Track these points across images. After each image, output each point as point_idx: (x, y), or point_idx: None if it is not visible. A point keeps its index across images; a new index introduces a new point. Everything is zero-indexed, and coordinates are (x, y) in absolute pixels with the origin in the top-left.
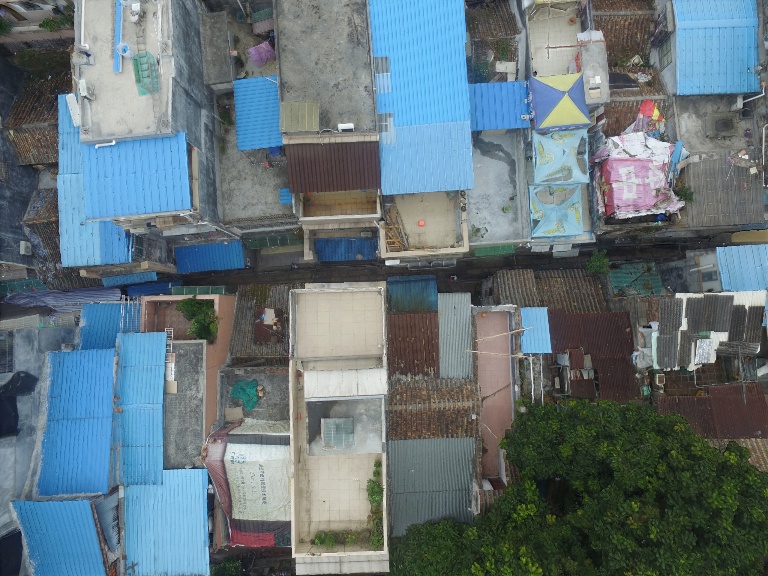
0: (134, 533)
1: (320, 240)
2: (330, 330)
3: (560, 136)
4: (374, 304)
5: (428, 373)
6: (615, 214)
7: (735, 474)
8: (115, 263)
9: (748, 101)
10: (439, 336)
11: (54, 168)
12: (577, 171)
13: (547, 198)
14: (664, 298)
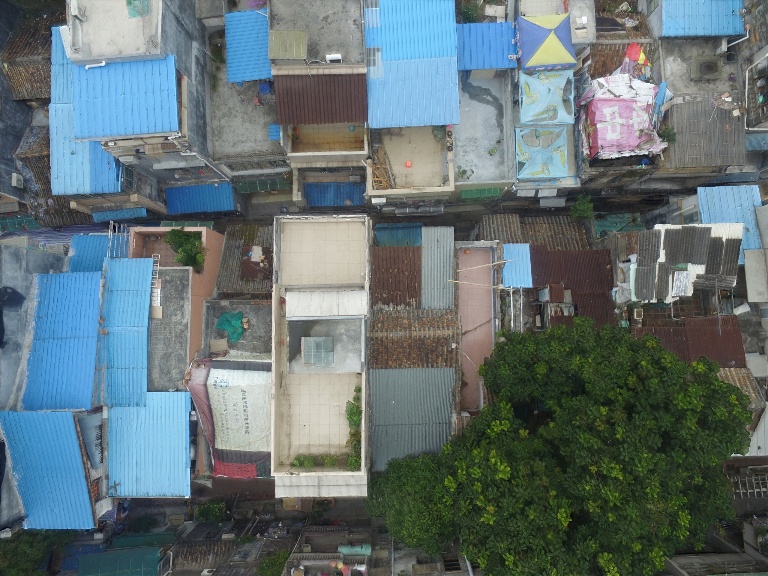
0: (117, 453)
1: (309, 185)
2: (314, 259)
3: (546, 76)
4: (358, 234)
5: (410, 303)
6: (599, 154)
7: (702, 382)
8: (104, 193)
9: (733, 45)
10: (422, 268)
11: (47, 106)
12: (562, 111)
13: (534, 143)
14: (643, 230)
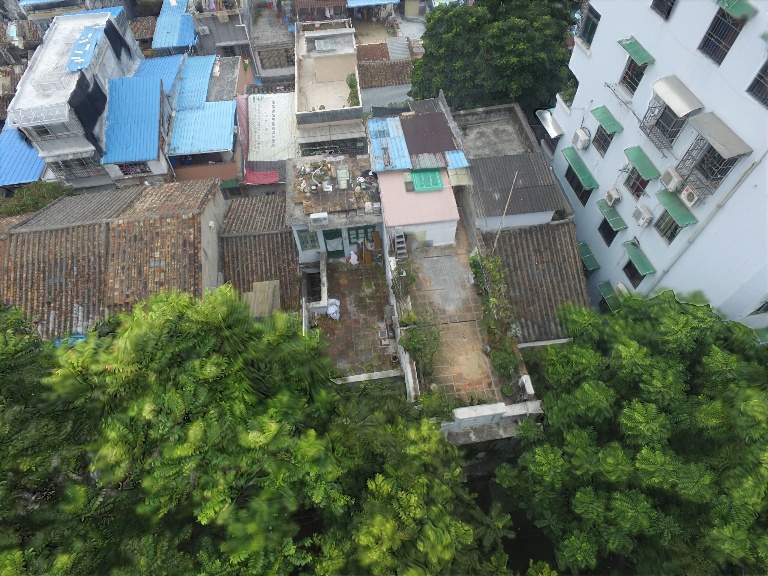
0: (179, 133)
1: None
2: None
3: None
4: None
5: None
6: None
7: None
8: (185, 47)
9: None
10: (388, 48)
11: (146, 49)
12: None
13: None
14: None
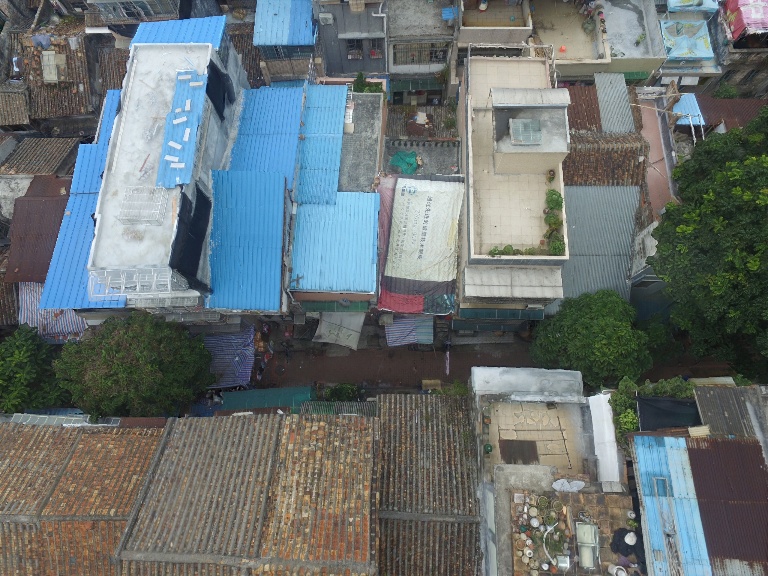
0: (302, 248)
1: None
2: None
3: None
4: (539, 71)
5: (591, 129)
6: (746, 28)
7: None
8: (299, 46)
9: None
10: (598, 102)
11: (237, 8)
12: None
13: None
14: None
